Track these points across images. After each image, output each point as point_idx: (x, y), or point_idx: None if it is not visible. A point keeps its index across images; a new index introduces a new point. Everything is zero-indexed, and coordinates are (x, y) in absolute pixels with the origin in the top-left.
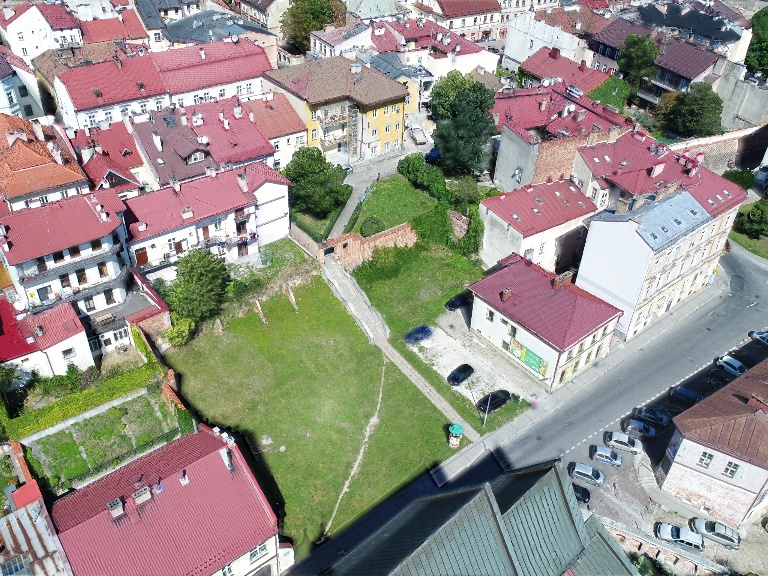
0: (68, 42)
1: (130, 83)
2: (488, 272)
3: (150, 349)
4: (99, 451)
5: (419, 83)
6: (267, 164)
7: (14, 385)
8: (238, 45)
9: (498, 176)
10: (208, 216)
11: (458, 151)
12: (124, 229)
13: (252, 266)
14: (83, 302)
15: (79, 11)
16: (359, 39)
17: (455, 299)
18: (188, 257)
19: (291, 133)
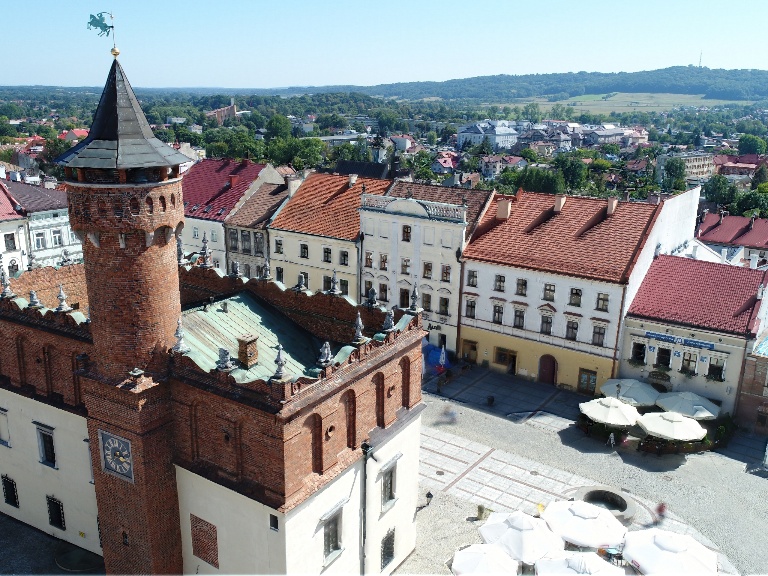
0: None
1: None
2: None
3: None
4: None
5: None
6: None
7: None
8: None
9: None
10: None
11: None
12: None
13: None
14: None
15: None
16: None
17: None
18: None
19: None
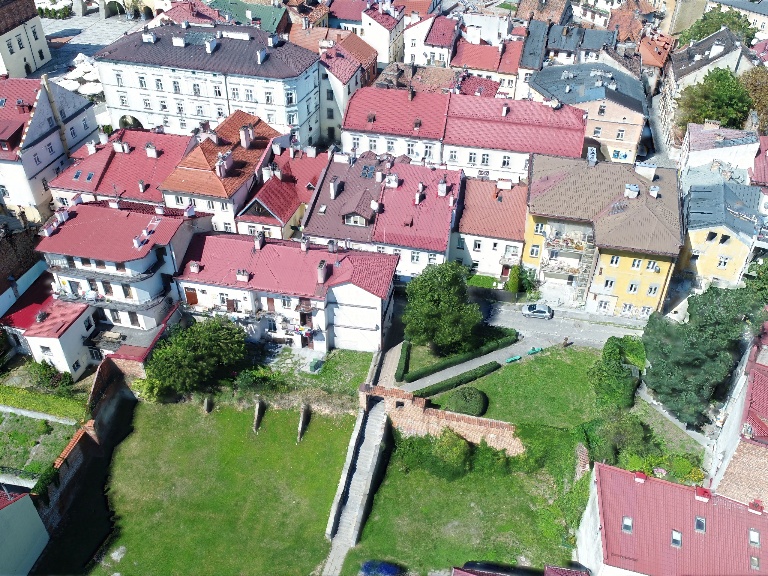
0: (436, 59)
1: (409, 118)
2: (573, 565)
3: (92, 389)
4: (2, 450)
5: (750, 245)
6: (435, 261)
7: (25, 350)
8: (557, 112)
9: (718, 441)
10: (262, 289)
11: None
12: (174, 262)
13: (300, 364)
14: (109, 311)
15: (468, 31)
16: (733, 153)
17: (480, 565)
18: (210, 320)
19: (500, 237)
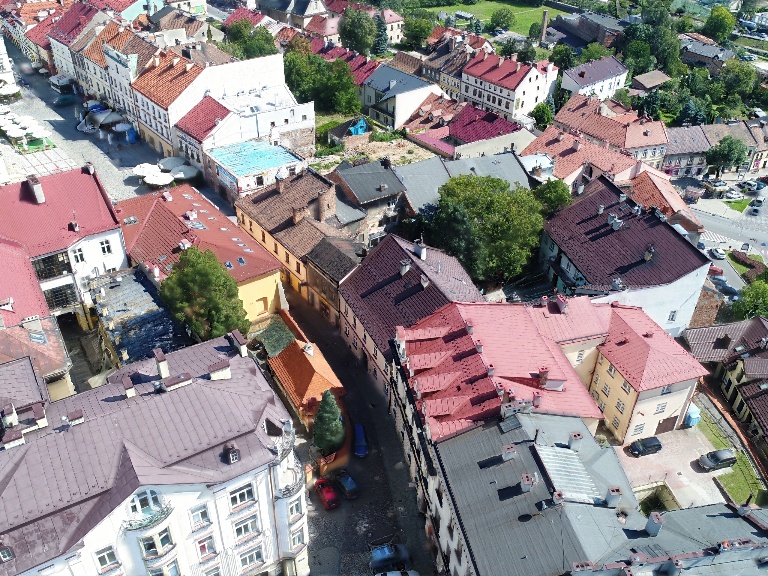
0: None
1: None
2: None
3: None
4: None
5: None
6: None
7: None
8: None
9: None
10: None
11: None
12: None
13: None
14: None
15: None
16: None
17: None
18: None
19: None
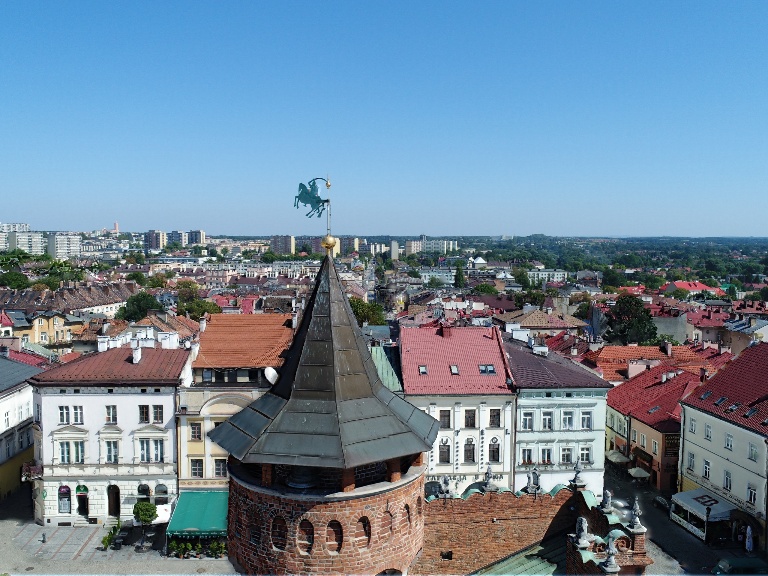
0: None
1: None
2: None
3: None
4: None
5: None
6: None
7: None
8: None
9: None
10: None
11: (654, 333)
12: None
13: None
14: None
15: None
16: None
17: None
18: None
19: None
